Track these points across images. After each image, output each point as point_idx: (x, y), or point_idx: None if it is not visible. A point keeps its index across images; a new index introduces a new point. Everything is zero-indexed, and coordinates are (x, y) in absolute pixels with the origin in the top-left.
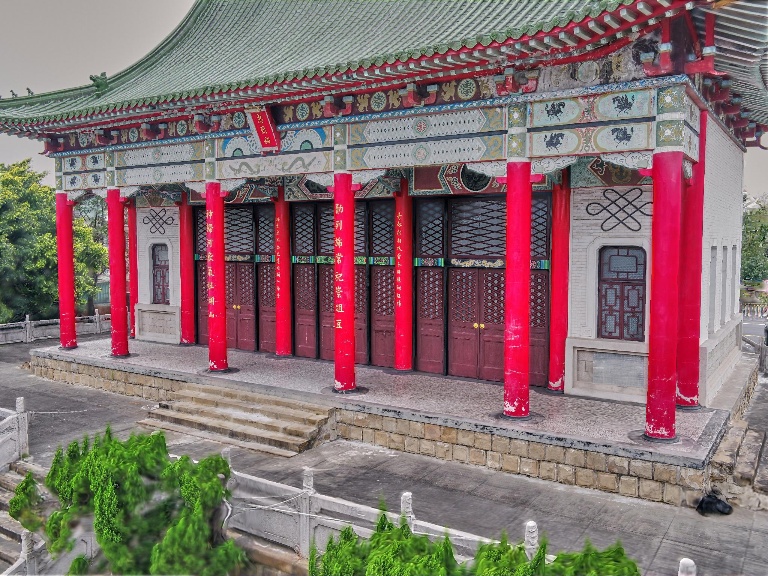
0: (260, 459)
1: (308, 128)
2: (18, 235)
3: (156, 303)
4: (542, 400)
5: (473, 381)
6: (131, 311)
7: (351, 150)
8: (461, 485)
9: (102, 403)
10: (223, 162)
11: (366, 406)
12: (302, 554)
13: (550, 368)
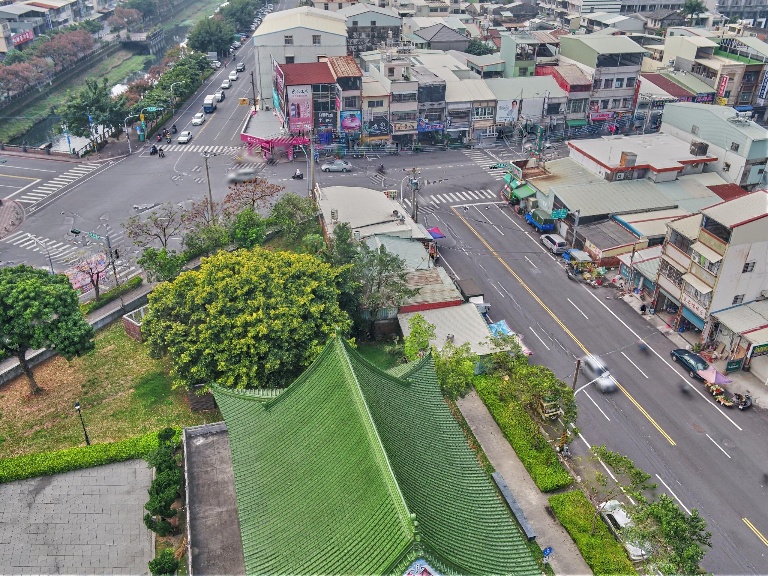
0: None
1: None
2: (300, 342)
3: None
4: None
5: None
6: None
7: None
8: None
9: None
10: None
11: None
12: None
13: None
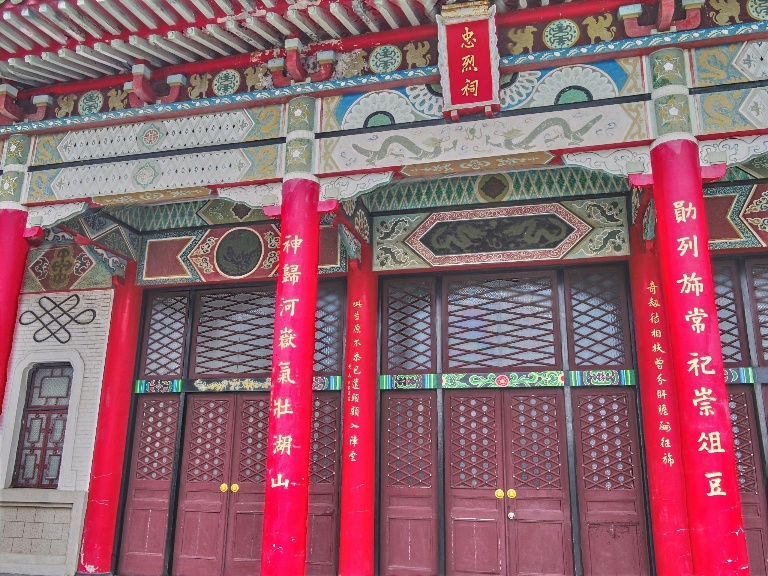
0: None
1: (577, 63)
2: None
3: (19, 486)
4: None
5: None
6: None
7: (701, 96)
8: None
9: None
10: (337, 139)
11: None
12: None
13: None
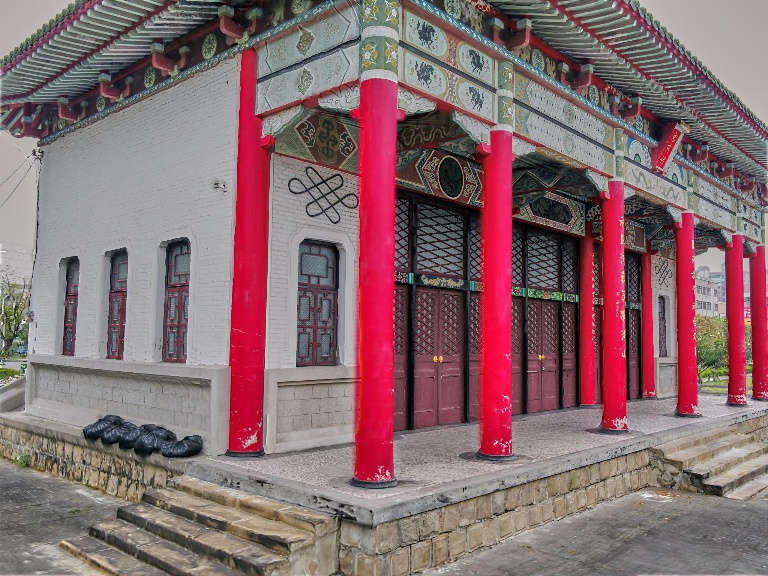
0: None
1: (676, 163)
2: None
3: (301, 365)
4: None
5: None
6: (255, 389)
7: None
8: None
9: (652, 518)
10: (628, 163)
11: (737, 417)
12: None
13: (650, 382)
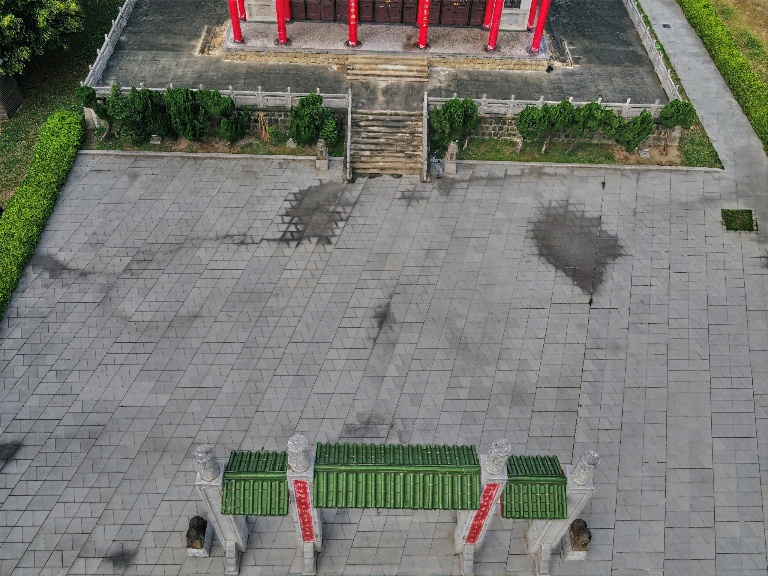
0: (421, 85)
1: None
2: None
3: None
4: (488, 36)
5: (454, 27)
6: (241, 5)
7: None
8: (487, 79)
9: (308, 72)
10: None
11: (442, 55)
12: (481, 114)
13: (486, 20)
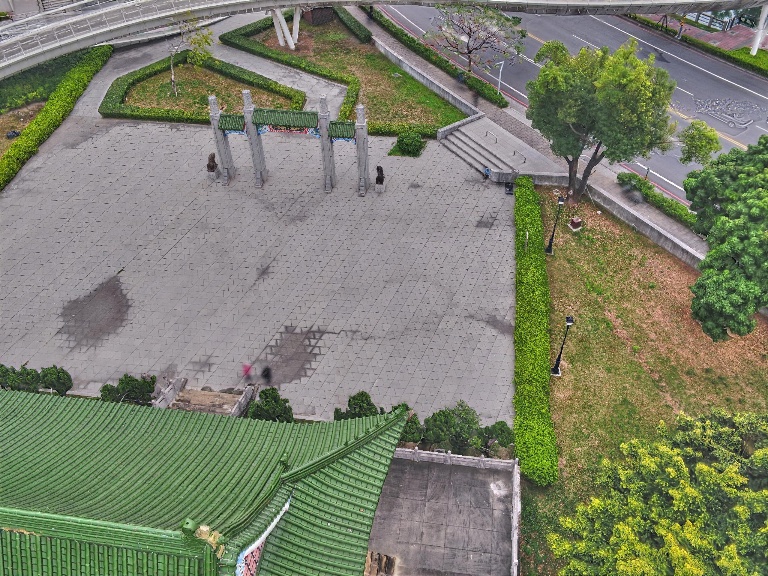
0: None
1: None
2: None
3: None
4: None
5: None
6: None
7: None
8: None
9: None
10: None
11: None
12: None
13: None
